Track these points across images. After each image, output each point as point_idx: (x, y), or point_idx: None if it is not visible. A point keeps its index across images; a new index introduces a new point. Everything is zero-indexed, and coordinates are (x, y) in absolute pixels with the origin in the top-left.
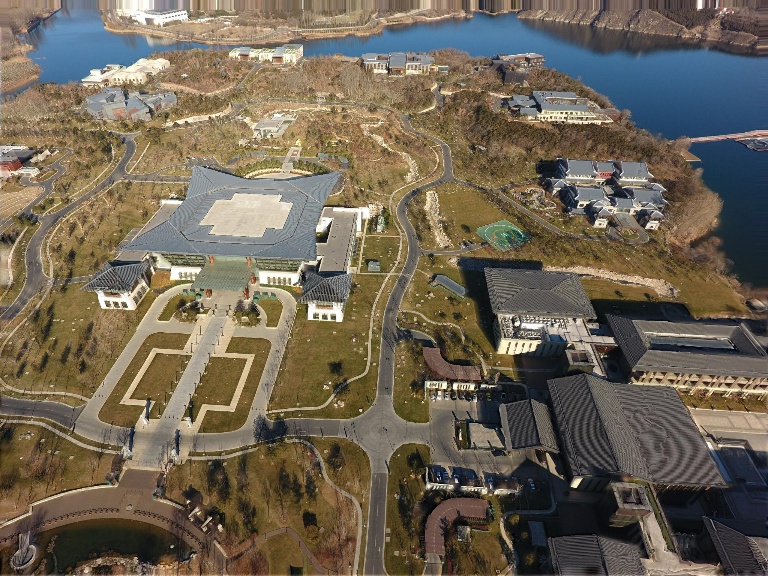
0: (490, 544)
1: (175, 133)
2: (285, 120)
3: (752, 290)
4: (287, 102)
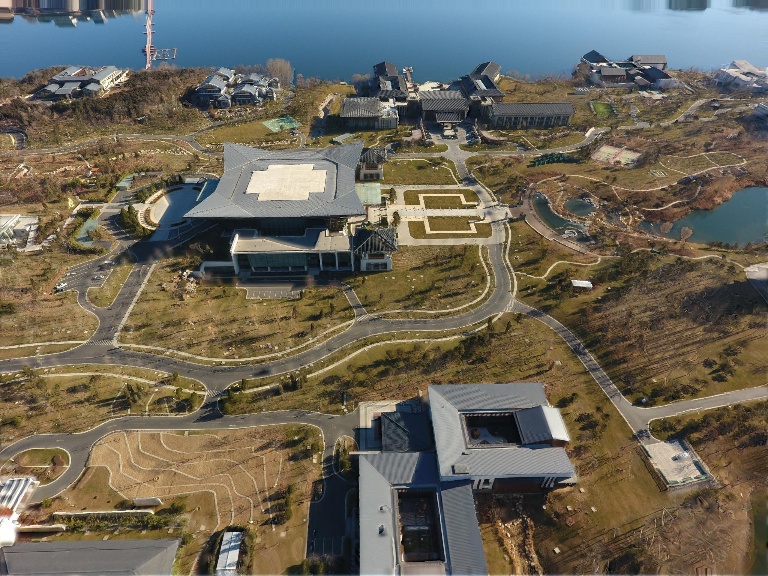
0: None
1: None
2: None
3: (337, 80)
4: None
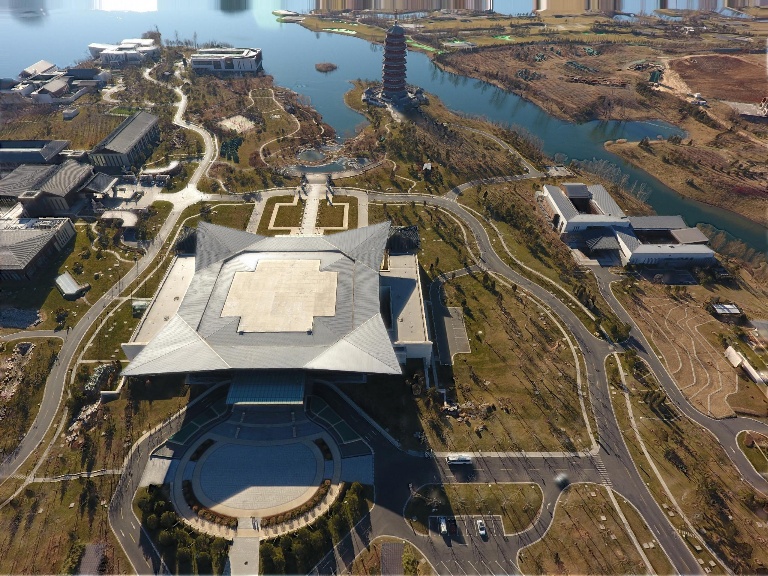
0: (150, 168)
1: None
2: None
3: None
4: None
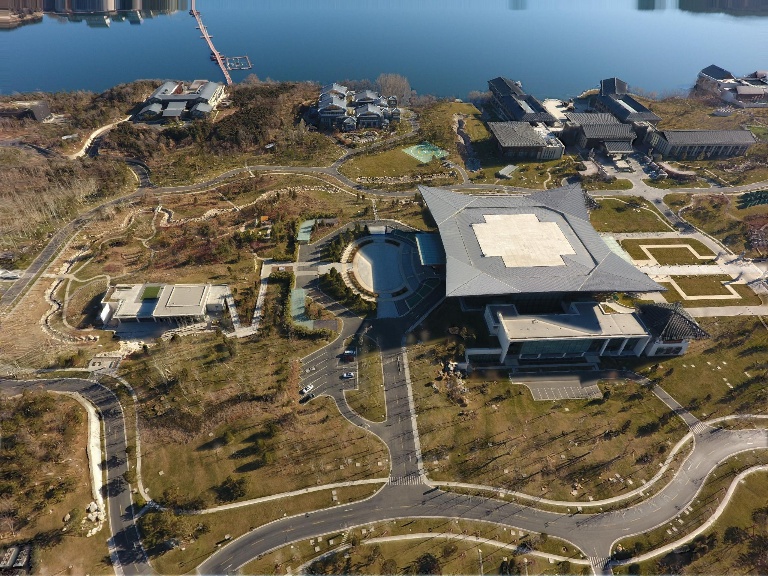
0: None
1: (172, 469)
2: (140, 296)
3: (453, 97)
4: (5, 318)
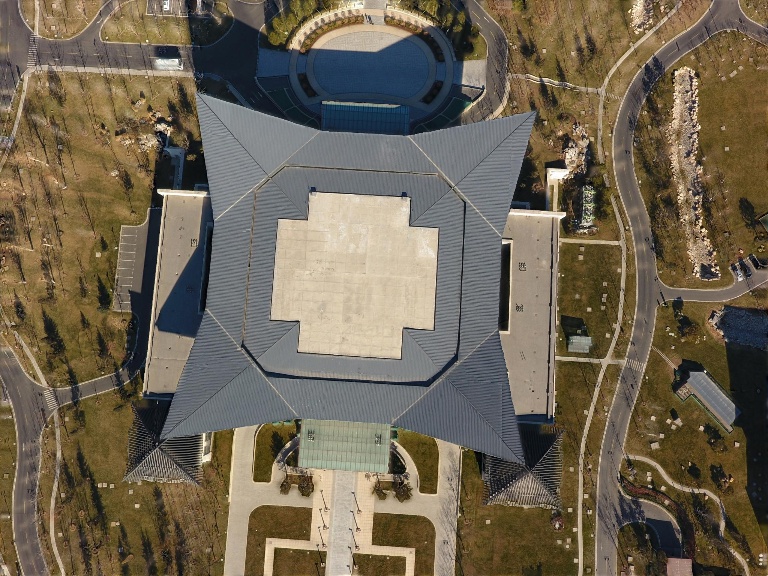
0: None
1: None
2: None
3: None
4: None
